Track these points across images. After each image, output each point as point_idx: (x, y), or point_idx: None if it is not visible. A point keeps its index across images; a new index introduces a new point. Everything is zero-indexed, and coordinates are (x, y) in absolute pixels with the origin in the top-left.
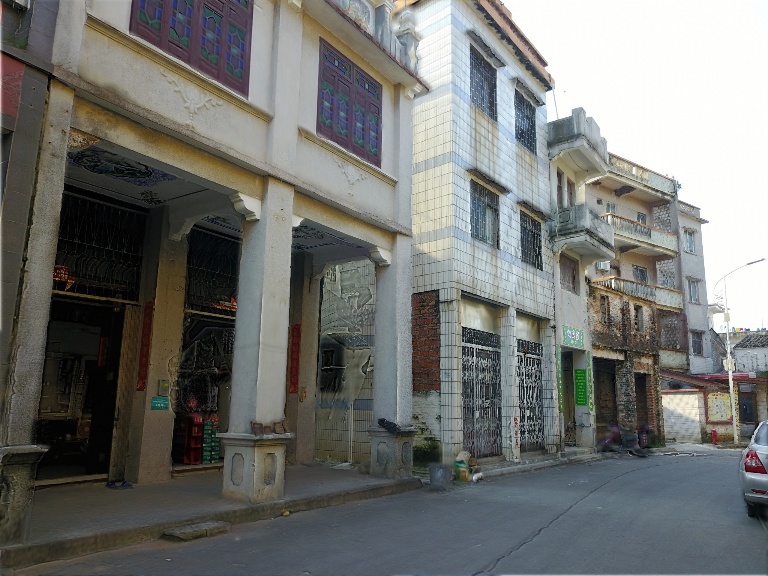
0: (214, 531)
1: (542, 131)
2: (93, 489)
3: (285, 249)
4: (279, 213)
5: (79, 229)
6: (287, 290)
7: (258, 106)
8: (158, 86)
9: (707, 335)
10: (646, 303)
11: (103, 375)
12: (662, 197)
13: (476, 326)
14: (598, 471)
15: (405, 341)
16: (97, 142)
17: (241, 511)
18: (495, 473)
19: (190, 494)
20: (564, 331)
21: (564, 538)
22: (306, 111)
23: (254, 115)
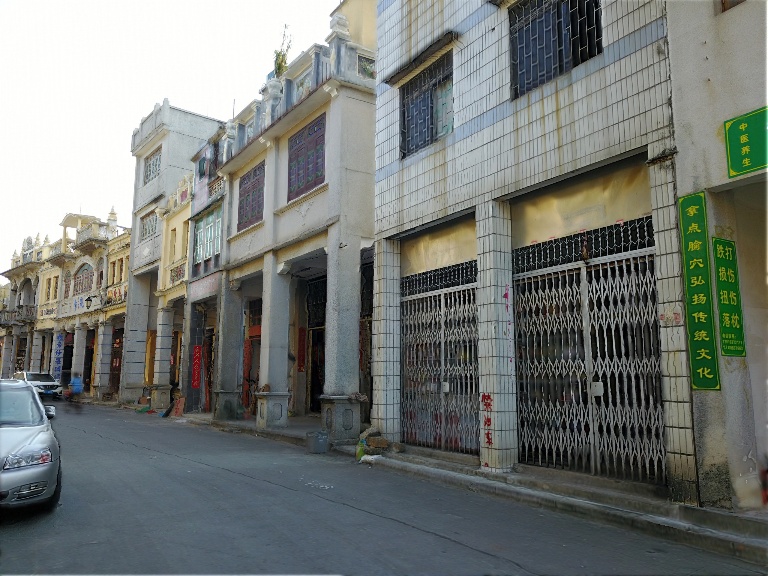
0: None
1: None
2: None
3: None
4: None
5: None
6: None
7: None
8: (242, 246)
9: None
10: None
11: None
12: None
13: (447, 262)
14: (478, 523)
15: None
16: (238, 280)
17: (247, 428)
18: (392, 464)
19: (295, 424)
20: (738, 135)
21: None
22: None
23: (263, 226)
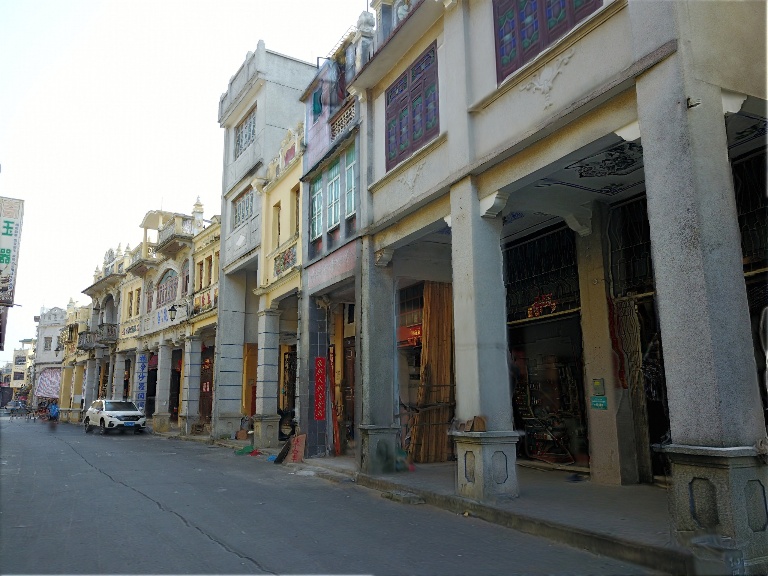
0: (395, 498)
1: None
2: (568, 478)
3: (467, 244)
4: (460, 213)
5: (544, 262)
6: (472, 284)
7: (445, 131)
8: None
9: None
10: None
11: (583, 378)
12: None
13: None
14: None
15: (676, 269)
16: None
17: None
18: None
19: None
20: None
21: (204, 558)
22: (485, 78)
23: (442, 144)
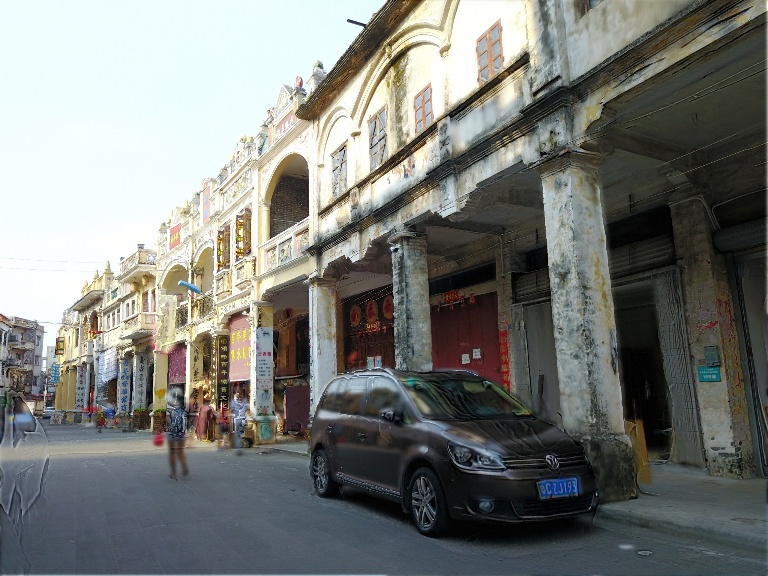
0: None
1: (7, 338)
2: None
3: None
4: None
5: None
6: None
7: None
8: None
9: (39, 377)
10: (24, 375)
11: None
12: (31, 328)
13: None
14: None
15: None
16: None
17: None
18: None
19: None
20: None
21: None
22: None
23: None
